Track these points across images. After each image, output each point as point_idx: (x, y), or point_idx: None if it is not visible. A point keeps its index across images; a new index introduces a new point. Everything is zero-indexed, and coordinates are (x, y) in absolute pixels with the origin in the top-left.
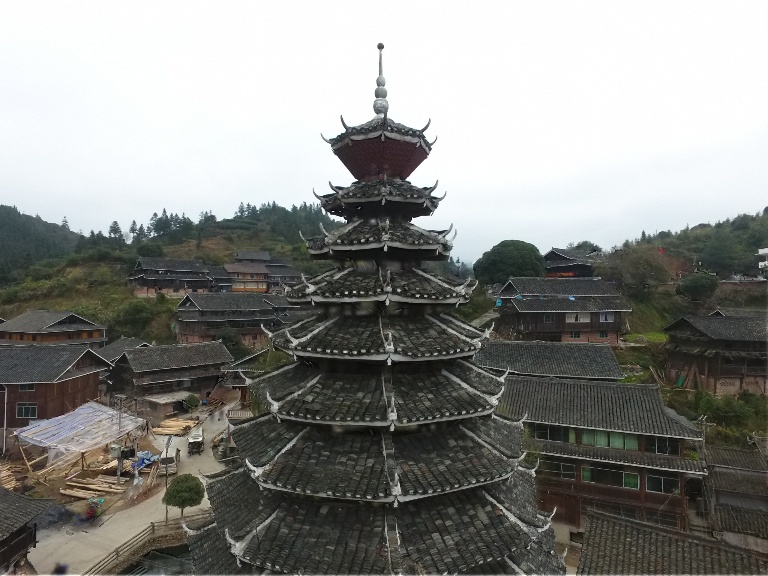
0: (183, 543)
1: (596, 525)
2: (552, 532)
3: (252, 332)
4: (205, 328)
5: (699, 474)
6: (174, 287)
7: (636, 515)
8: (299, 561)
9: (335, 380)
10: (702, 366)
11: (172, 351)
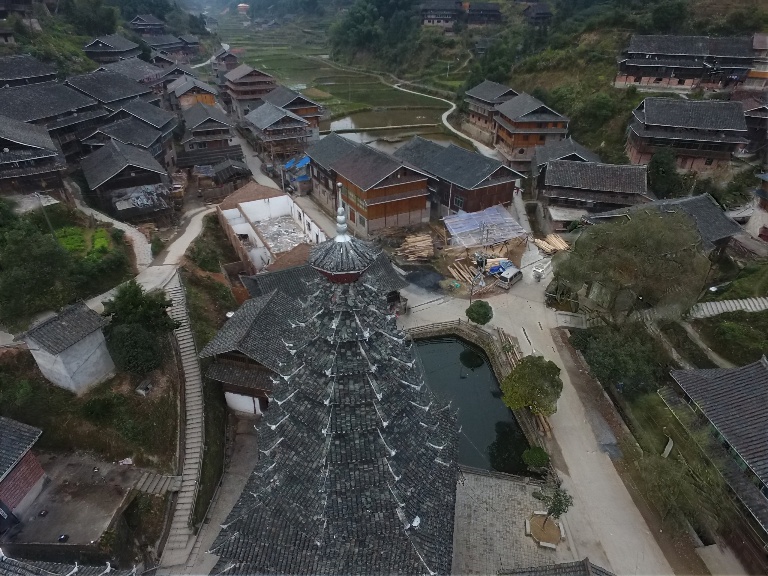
0: (471, 341)
1: (577, 570)
2: (392, 508)
3: (706, 156)
4: (646, 144)
5: None
6: (658, 75)
7: None
8: (270, 419)
9: None
10: None
11: (589, 169)
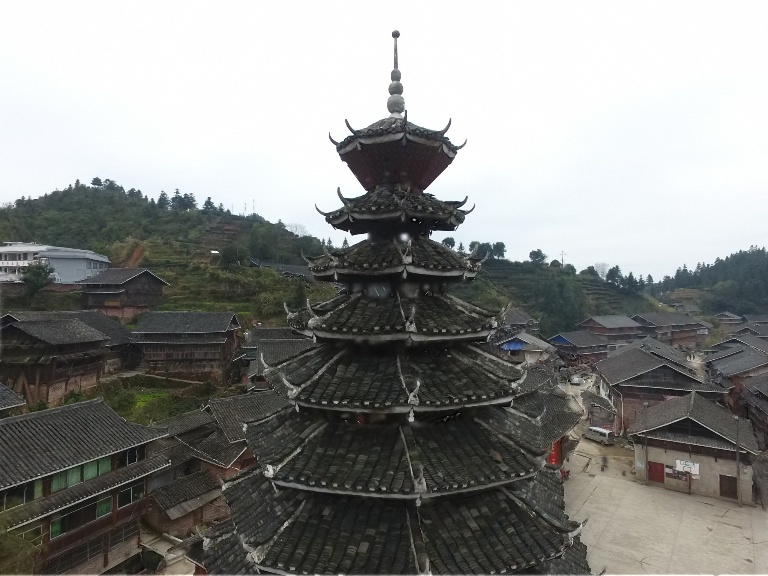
0: None
1: None
2: None
3: None
4: None
5: (165, 467)
6: None
7: (102, 543)
8: None
9: (487, 420)
10: (32, 375)
11: None
